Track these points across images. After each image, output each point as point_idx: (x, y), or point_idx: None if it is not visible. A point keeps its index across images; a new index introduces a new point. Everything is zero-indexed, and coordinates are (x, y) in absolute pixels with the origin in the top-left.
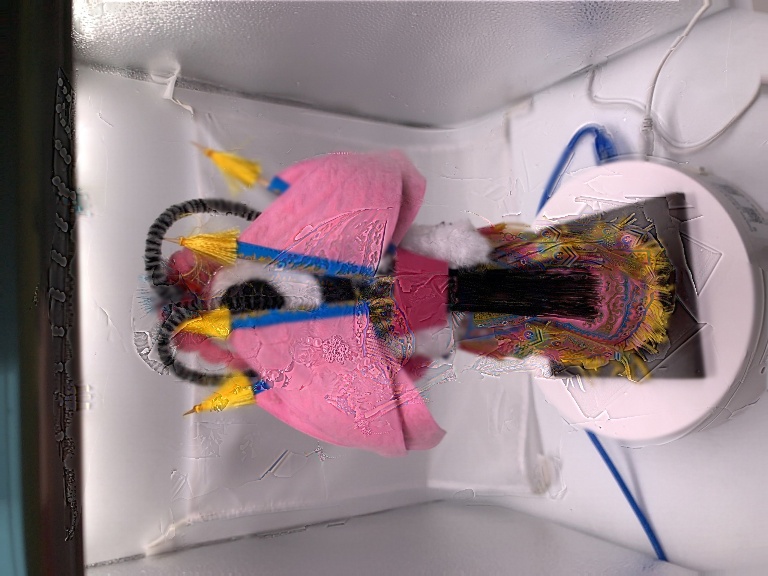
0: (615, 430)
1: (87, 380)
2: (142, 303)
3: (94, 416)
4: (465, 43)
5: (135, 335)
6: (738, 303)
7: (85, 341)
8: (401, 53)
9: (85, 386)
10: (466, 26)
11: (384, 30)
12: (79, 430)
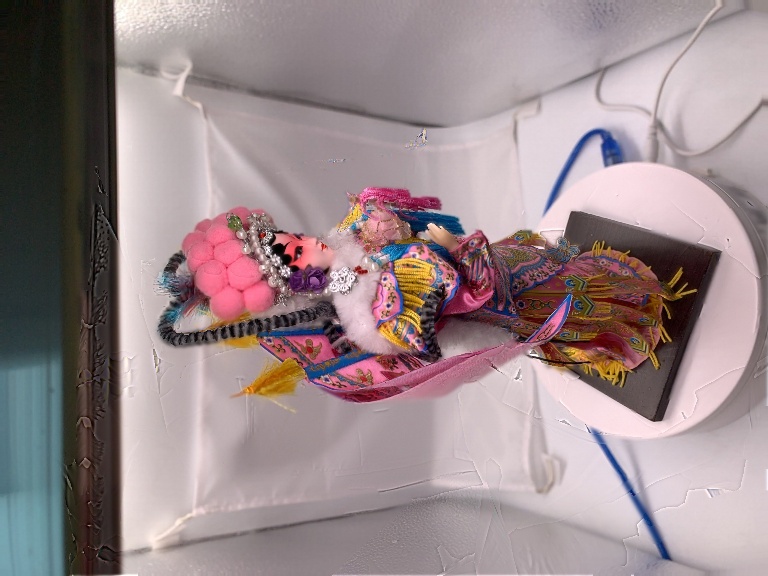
0: (715, 223)
1: (126, 402)
2: (139, 257)
3: (137, 351)
4: (449, 525)
5: (160, 331)
6: (560, 202)
7: (121, 450)
8: (422, 575)
9: (123, 392)
10: (435, 518)
11: (387, 567)
12: (115, 334)
